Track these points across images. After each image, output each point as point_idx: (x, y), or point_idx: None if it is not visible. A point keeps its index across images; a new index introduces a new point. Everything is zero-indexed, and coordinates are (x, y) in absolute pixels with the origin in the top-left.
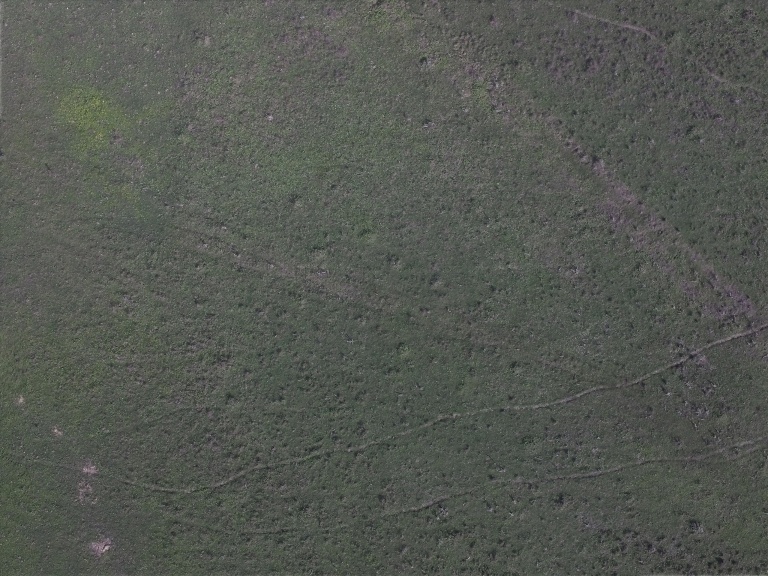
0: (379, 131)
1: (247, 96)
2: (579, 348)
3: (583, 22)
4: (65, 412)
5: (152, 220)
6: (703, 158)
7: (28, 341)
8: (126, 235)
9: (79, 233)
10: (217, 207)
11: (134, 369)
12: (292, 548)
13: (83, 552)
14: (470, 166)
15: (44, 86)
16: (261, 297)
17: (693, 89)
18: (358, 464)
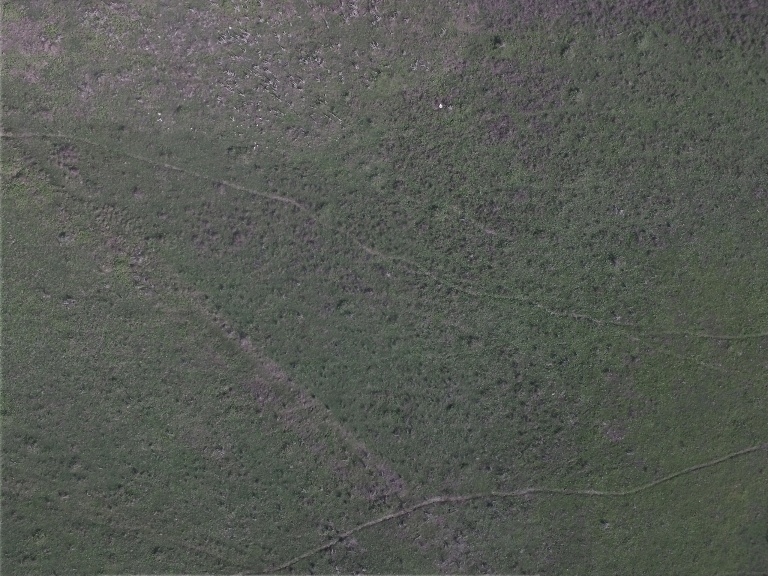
0: (18, 308)
1: None
2: (225, 532)
3: (230, 194)
4: None
5: None
6: (354, 333)
7: None
8: None
9: None
10: None
11: None
12: None
13: None
14: (112, 344)
15: None
16: None
17: (344, 262)
18: None
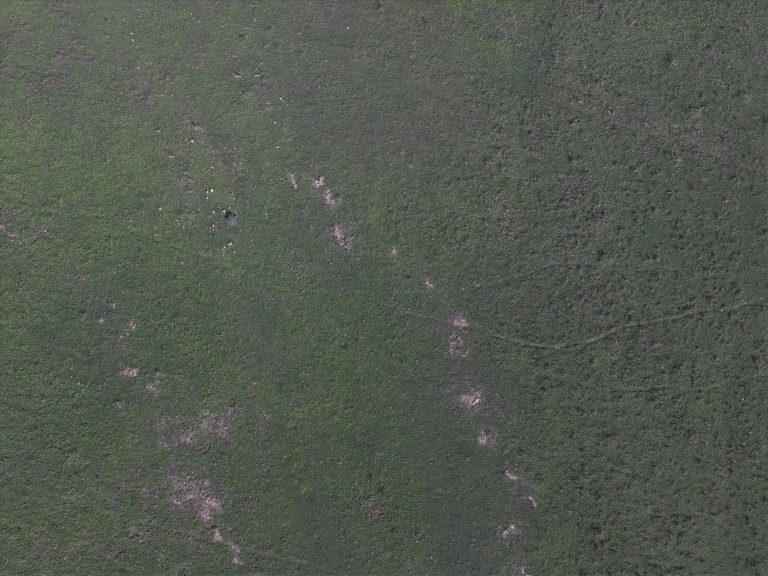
0: None
1: None
2: None
3: None
4: (436, 265)
5: (524, 77)
6: None
7: (401, 193)
8: (499, 91)
9: (453, 87)
10: (592, 64)
11: (506, 224)
12: (664, 406)
13: (453, 404)
14: None
15: None
16: (634, 155)
17: None
18: (731, 324)
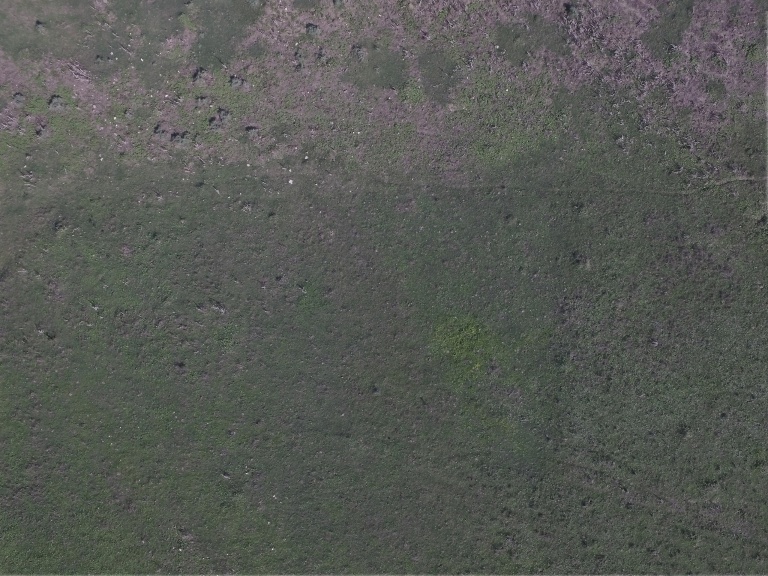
0: None
1: (630, 321)
2: None
3: None
4: None
5: (531, 454)
6: None
7: None
8: (505, 471)
9: (457, 471)
10: (602, 440)
11: None
12: None
13: None
14: None
15: (417, 315)
16: (652, 535)
17: None
18: None
